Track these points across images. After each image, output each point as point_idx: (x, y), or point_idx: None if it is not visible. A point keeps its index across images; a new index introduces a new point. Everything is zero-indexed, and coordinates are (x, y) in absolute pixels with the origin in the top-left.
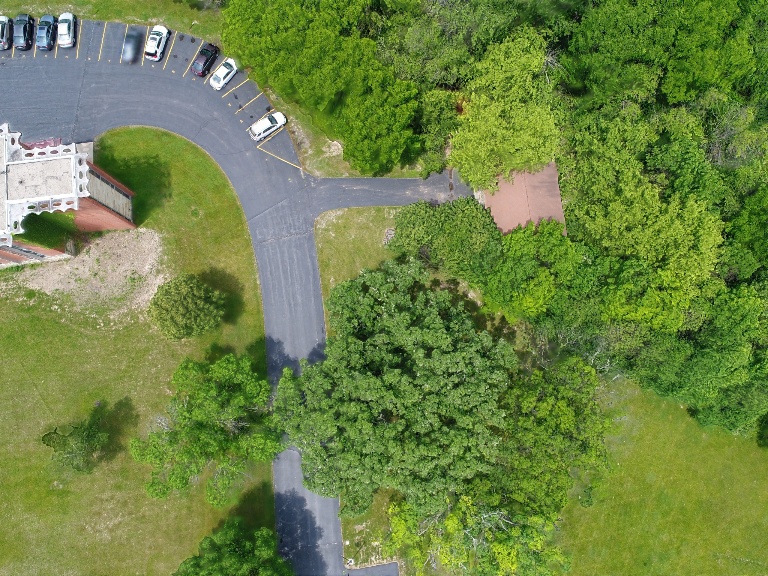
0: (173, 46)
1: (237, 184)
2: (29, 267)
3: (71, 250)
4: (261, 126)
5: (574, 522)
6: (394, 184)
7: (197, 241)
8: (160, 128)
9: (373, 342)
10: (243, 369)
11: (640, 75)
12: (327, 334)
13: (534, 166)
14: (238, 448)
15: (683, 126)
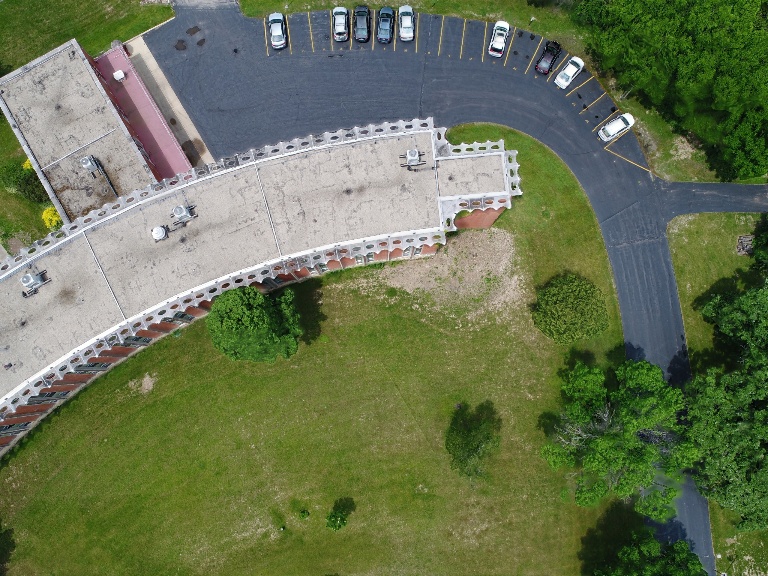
0: (513, 42)
1: (586, 185)
2: (389, 264)
3: None
4: (615, 127)
5: None
6: (742, 190)
7: (550, 242)
8: (505, 126)
9: None
10: (655, 376)
11: None
12: (687, 341)
13: None
14: None
15: None
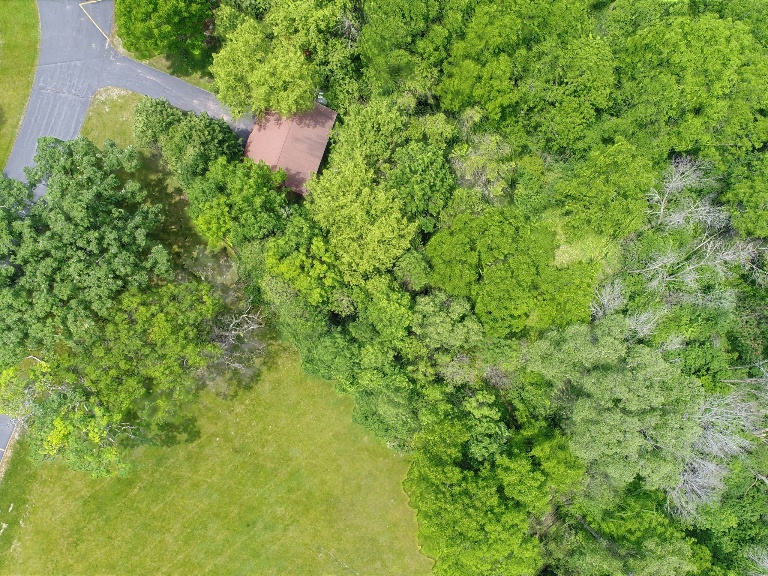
0: None
1: (45, 29)
2: None
3: None
4: None
5: (201, 458)
6: (186, 89)
7: None
8: None
9: None
10: None
11: (414, 67)
12: None
13: (306, 120)
14: None
15: (437, 132)
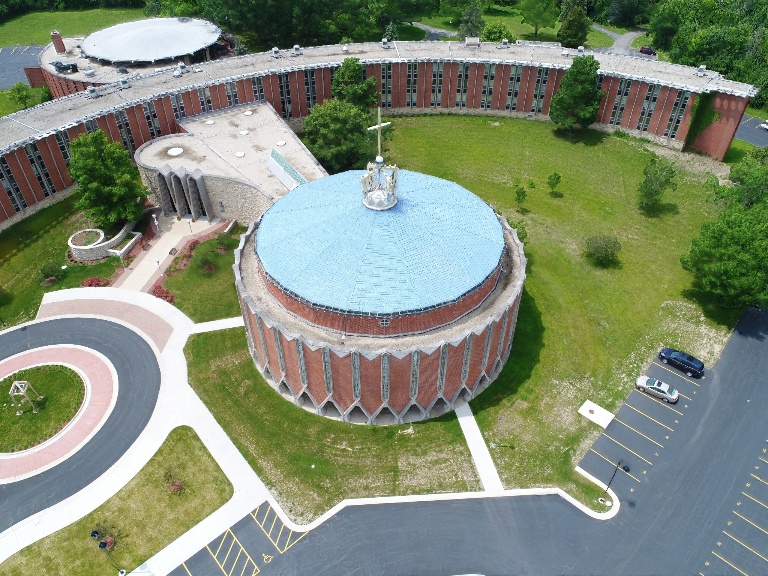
0: None
1: None
2: (652, 144)
3: (683, 146)
4: None
5: None
6: None
7: None
8: (755, 145)
9: None
10: None
11: None
12: None
13: None
14: None
15: None
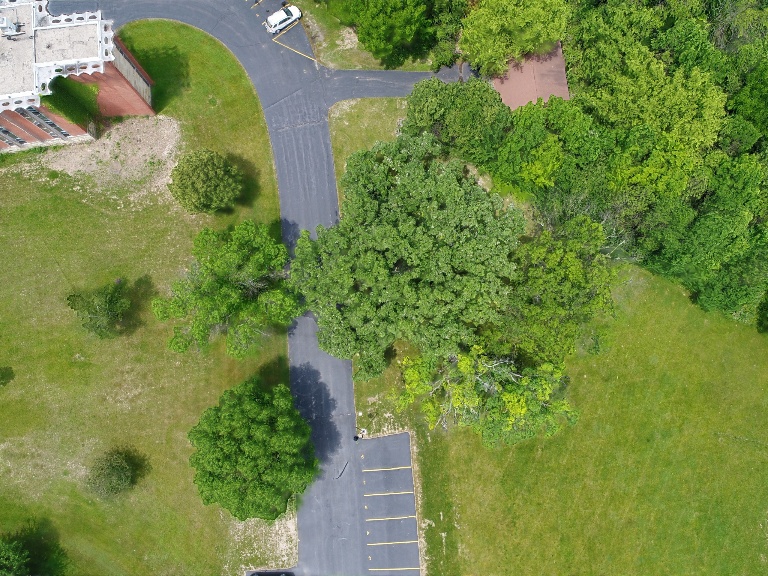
0: None
1: (253, 75)
2: (52, 149)
3: (93, 132)
4: (277, 17)
5: (580, 400)
6: (406, 77)
7: (214, 128)
8: (178, 21)
9: (388, 206)
10: (262, 234)
11: None
12: None
13: (542, 55)
14: (257, 308)
15: (687, 9)
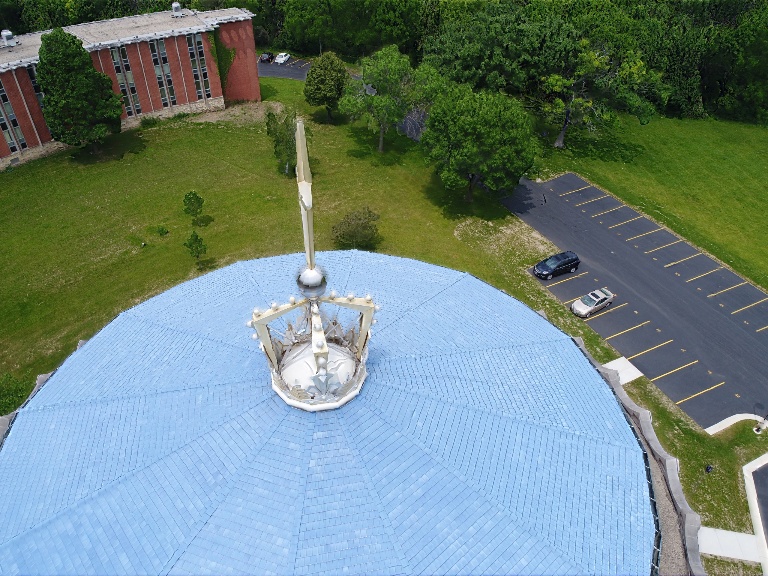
0: None
1: None
2: (191, 116)
3: None
4: None
5: (660, 152)
6: None
7: None
8: None
9: None
10: None
11: None
12: None
13: None
14: None
15: None
